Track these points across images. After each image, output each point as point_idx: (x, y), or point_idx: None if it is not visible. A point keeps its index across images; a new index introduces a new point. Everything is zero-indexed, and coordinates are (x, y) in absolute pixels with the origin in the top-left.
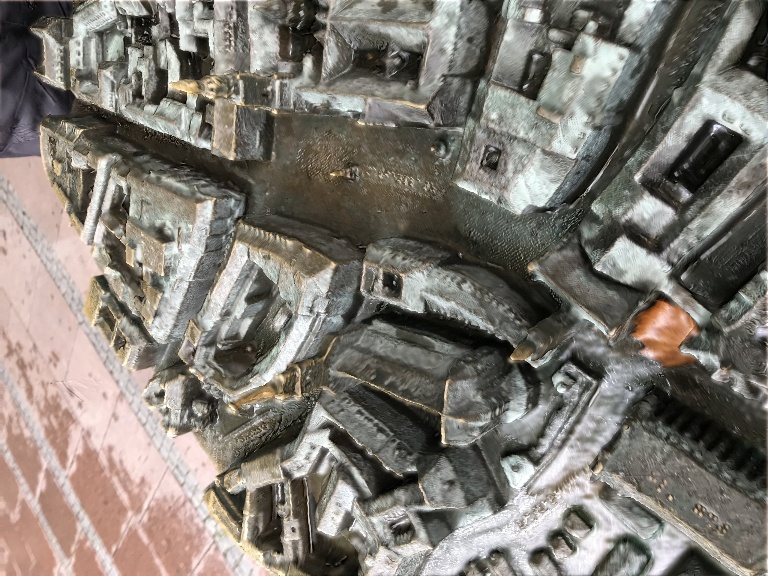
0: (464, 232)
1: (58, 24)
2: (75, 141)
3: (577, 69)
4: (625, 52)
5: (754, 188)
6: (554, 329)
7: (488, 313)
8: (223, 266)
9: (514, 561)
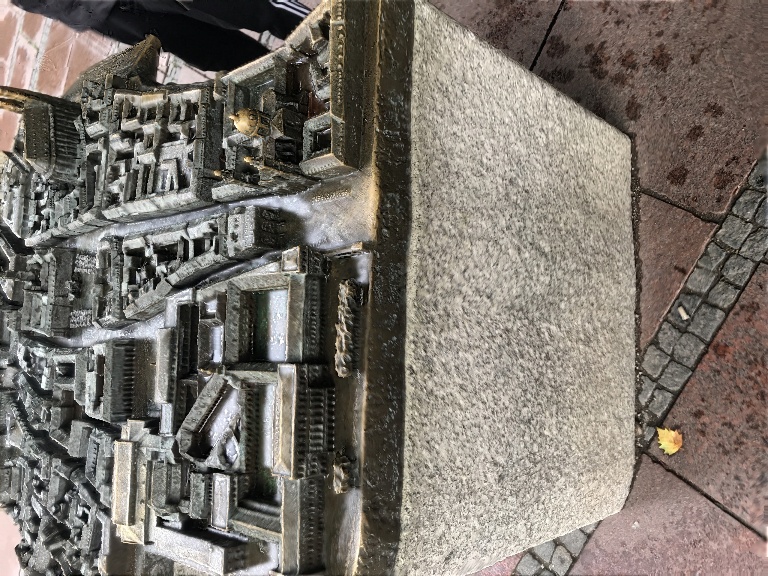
0: (34, 332)
1: None
2: None
3: None
4: None
5: None
6: (1, 373)
7: (11, 351)
8: (7, 251)
9: (1, 362)
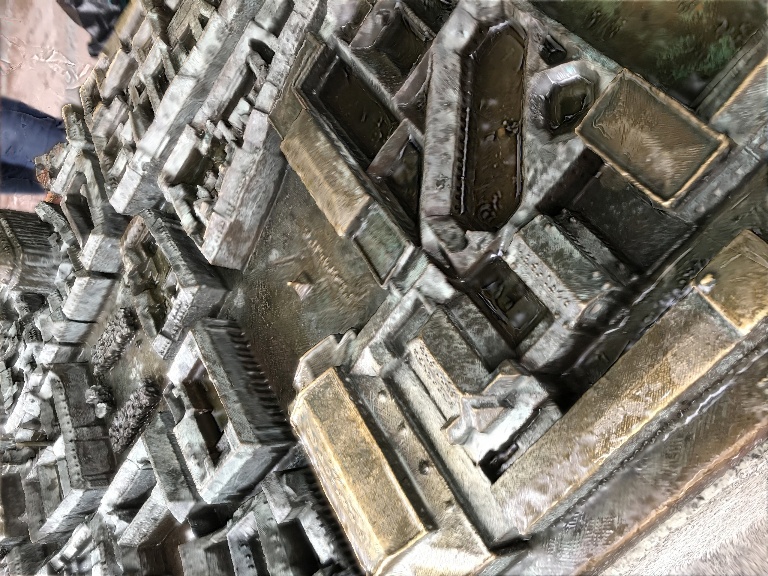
0: None
1: None
2: None
3: None
4: None
5: None
6: None
7: None
8: None
9: None
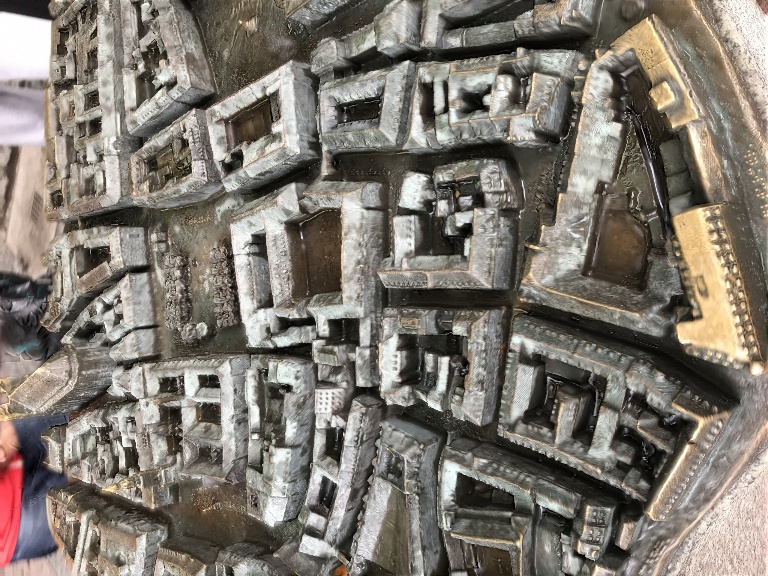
0: (270, 534)
1: (58, 432)
2: (68, 504)
3: (270, 461)
4: (289, 450)
5: (346, 504)
6: None
7: None
8: None
9: None
